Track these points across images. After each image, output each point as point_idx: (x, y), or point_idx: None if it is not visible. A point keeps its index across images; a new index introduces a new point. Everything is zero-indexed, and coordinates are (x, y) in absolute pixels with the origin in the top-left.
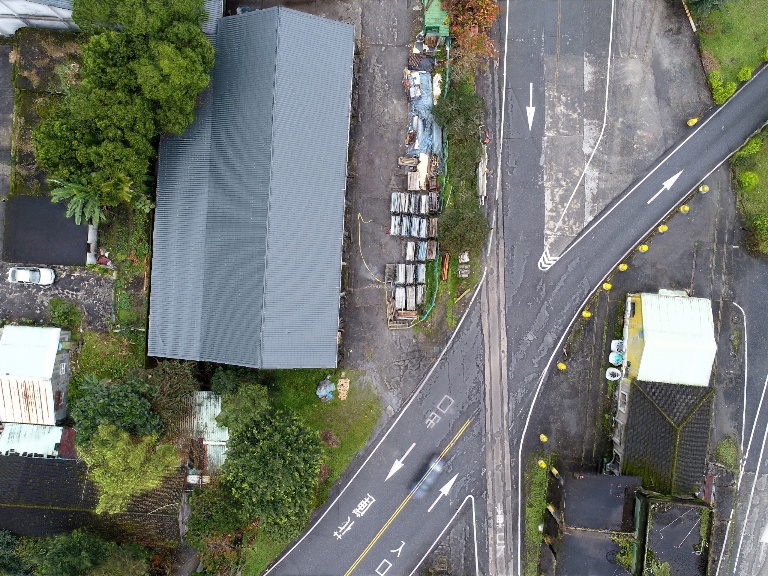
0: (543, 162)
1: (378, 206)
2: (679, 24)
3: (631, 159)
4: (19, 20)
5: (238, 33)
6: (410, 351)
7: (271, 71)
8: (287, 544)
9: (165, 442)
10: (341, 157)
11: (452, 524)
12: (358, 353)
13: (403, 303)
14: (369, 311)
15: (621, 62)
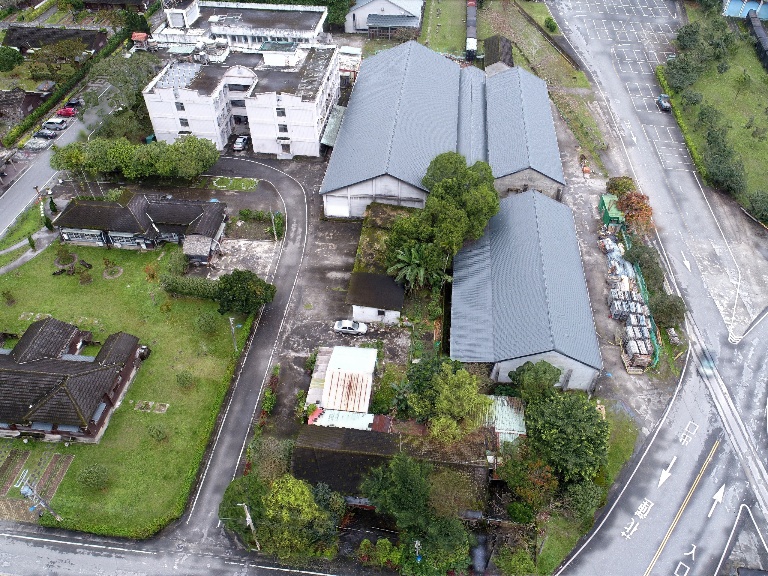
0: (706, 287)
1: (598, 303)
2: (762, 231)
3: (767, 288)
4: (370, 201)
5: (505, 205)
6: (649, 389)
7: (533, 212)
8: (577, 542)
9: (462, 428)
10: (578, 259)
11: (737, 530)
12: (607, 388)
13: (637, 350)
14: (608, 362)
15: (735, 245)
